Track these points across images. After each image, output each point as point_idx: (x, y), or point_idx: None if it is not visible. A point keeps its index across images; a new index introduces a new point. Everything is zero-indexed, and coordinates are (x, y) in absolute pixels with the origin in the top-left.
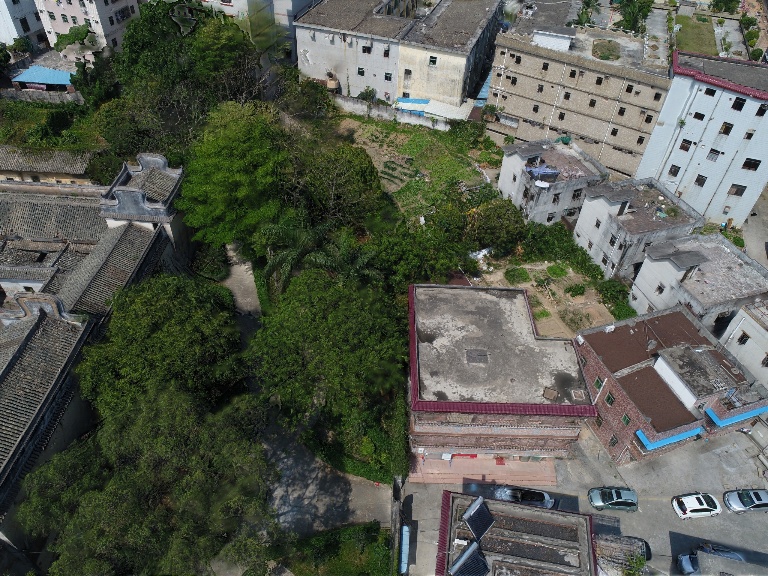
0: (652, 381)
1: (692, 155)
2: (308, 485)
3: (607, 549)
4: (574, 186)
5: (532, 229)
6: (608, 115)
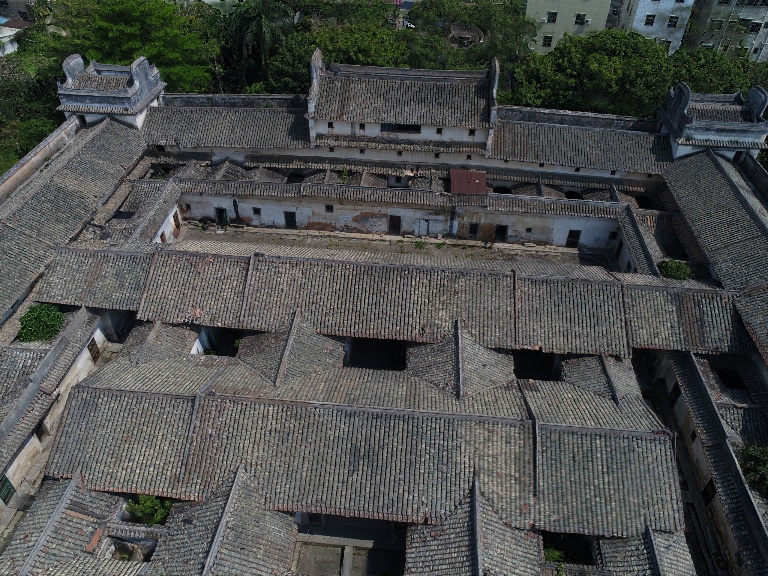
0: None
1: None
2: None
3: None
4: None
5: None
6: None
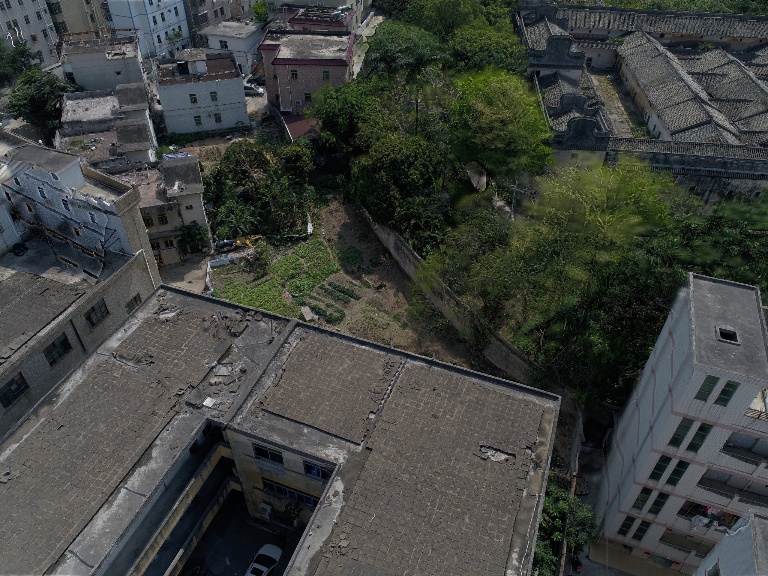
0: None
1: None
2: None
3: (285, 24)
4: None
5: (211, 173)
6: (31, 194)
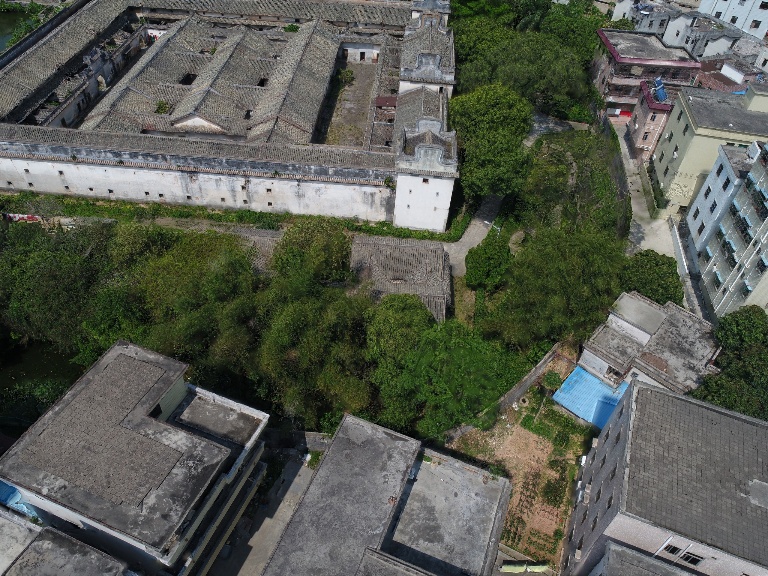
0: (720, 76)
1: (729, 3)
2: (549, 123)
3: None
4: (662, 17)
5: None
6: None
